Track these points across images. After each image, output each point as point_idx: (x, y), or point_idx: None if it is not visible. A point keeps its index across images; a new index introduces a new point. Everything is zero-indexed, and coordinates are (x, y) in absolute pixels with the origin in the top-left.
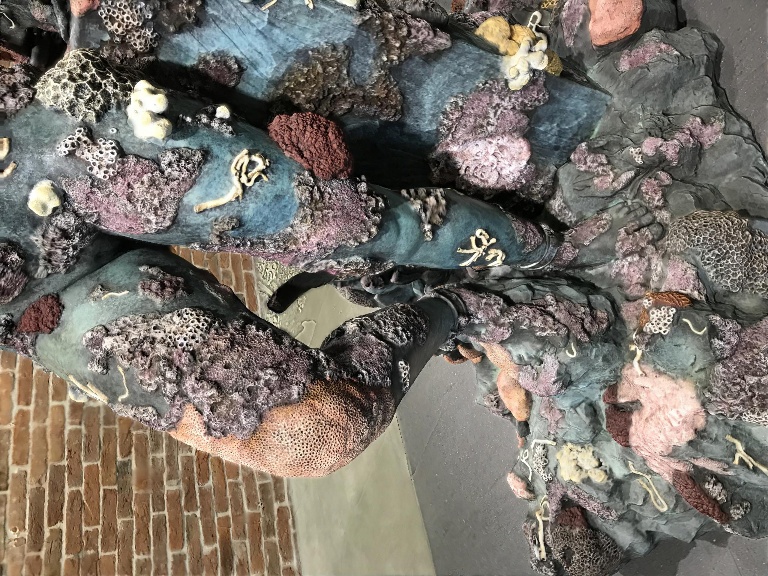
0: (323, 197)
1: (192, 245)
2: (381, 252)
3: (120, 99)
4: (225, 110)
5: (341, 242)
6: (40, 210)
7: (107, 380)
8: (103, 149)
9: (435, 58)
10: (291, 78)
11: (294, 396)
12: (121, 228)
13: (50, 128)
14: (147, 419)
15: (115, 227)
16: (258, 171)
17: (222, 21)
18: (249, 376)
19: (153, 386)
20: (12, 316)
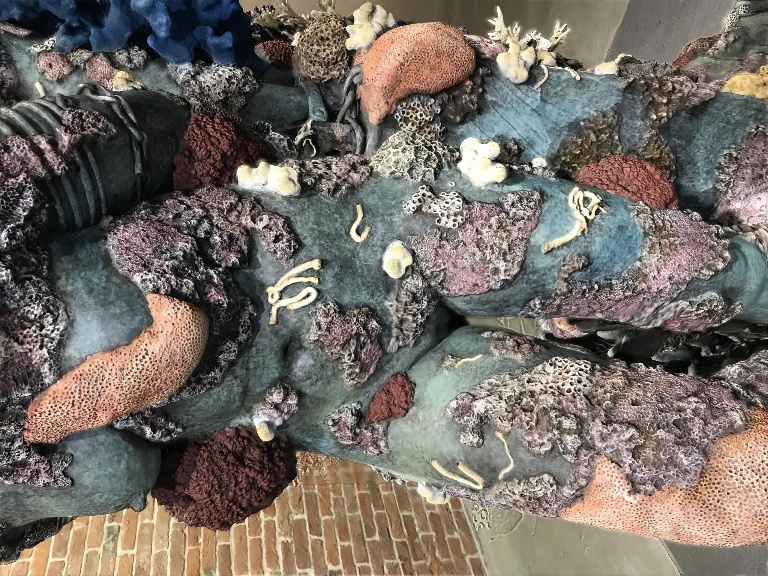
0: (664, 225)
1: (531, 303)
2: (731, 288)
3: (449, 160)
4: (542, 159)
5: (694, 273)
6: (396, 269)
7: (483, 453)
8: (448, 199)
9: (701, 111)
10: (566, 152)
11: (737, 423)
12: (465, 287)
13: (394, 192)
14: (540, 494)
15: (458, 288)
16: (596, 204)
17: (500, 106)
18: (668, 409)
19: (547, 445)
20: (361, 405)
